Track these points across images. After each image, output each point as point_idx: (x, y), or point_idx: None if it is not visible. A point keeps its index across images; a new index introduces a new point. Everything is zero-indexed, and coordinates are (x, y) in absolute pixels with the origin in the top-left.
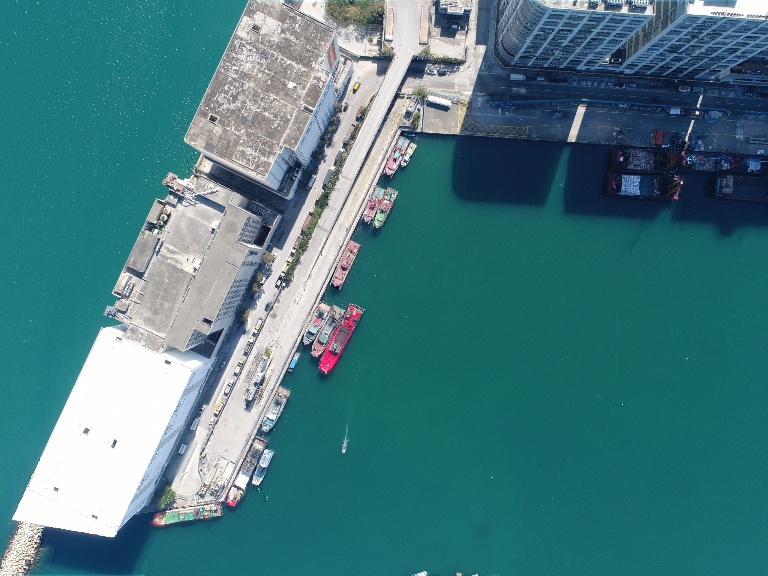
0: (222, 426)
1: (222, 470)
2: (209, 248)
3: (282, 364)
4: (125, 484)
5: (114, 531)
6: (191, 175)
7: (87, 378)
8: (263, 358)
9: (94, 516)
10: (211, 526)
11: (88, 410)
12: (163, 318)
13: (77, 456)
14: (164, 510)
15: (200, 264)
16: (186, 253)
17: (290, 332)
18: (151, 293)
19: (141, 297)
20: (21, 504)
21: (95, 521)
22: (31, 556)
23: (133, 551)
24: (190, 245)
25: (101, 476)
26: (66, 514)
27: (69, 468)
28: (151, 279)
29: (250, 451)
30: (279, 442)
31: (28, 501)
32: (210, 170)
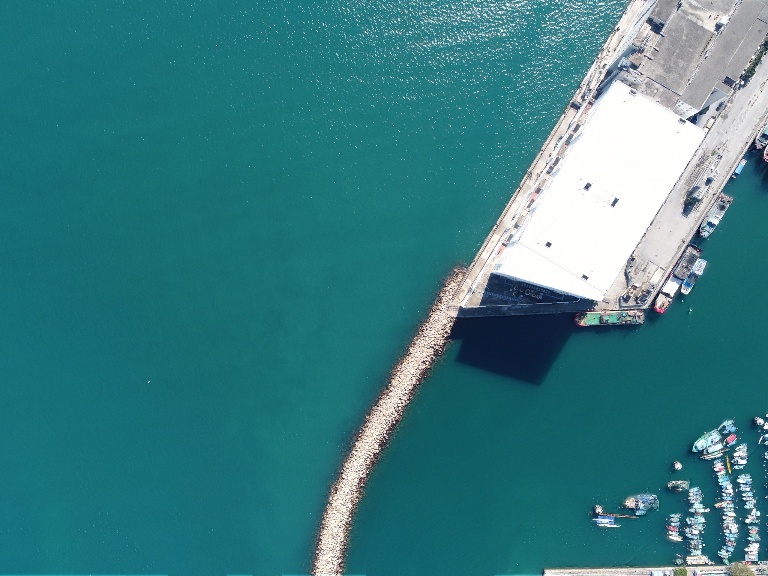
0: (655, 229)
1: (650, 275)
2: (741, 2)
3: (727, 169)
4: (621, 246)
5: (602, 295)
6: None
7: (593, 132)
8: (720, 155)
9: (584, 276)
10: (627, 335)
11: (591, 165)
12: (676, 77)
13: (575, 212)
14: (584, 311)
15: (729, 19)
16: (709, 10)
17: (740, 135)
18: (666, 50)
19: (655, 53)
20: (508, 257)
21: (583, 282)
22: (440, 346)
23: (542, 352)
24: (714, 1)
25: (599, 234)
26: (555, 272)
27: (565, 223)
28: (668, 35)
29: (684, 257)
30: (711, 253)
31: (516, 255)
32: None
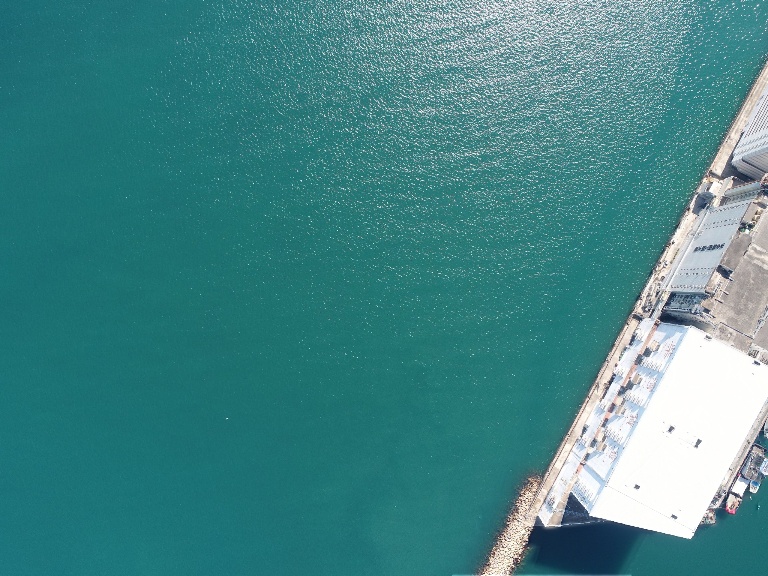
0: None
1: None
2: None
3: None
4: (707, 485)
5: (691, 532)
6: (701, 178)
7: (672, 376)
8: None
9: (673, 516)
10: (700, 533)
11: (673, 408)
12: (746, 318)
13: (660, 454)
14: None
15: None
16: None
17: None
18: (735, 293)
19: (725, 297)
20: (598, 500)
21: (672, 521)
22: (519, 554)
23: (619, 555)
24: None
25: (685, 476)
26: (645, 513)
27: (652, 466)
28: (736, 279)
29: (750, 458)
30: None
31: (605, 498)
32: (721, 173)
